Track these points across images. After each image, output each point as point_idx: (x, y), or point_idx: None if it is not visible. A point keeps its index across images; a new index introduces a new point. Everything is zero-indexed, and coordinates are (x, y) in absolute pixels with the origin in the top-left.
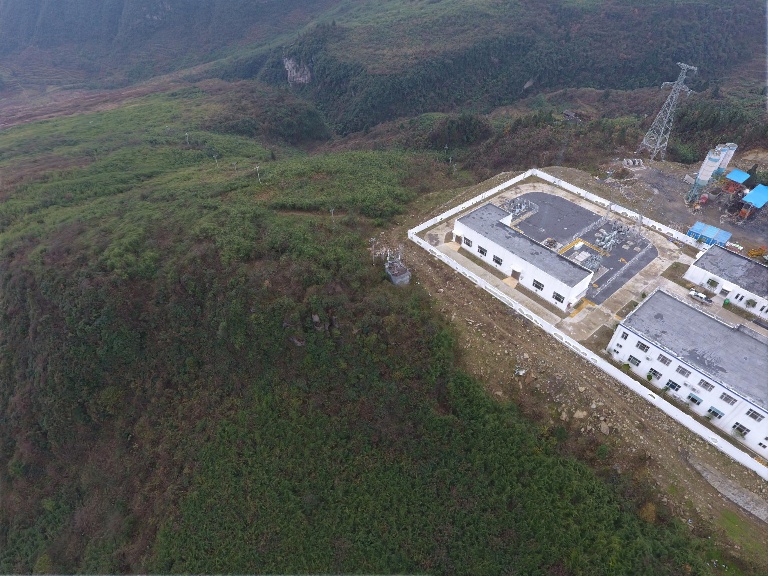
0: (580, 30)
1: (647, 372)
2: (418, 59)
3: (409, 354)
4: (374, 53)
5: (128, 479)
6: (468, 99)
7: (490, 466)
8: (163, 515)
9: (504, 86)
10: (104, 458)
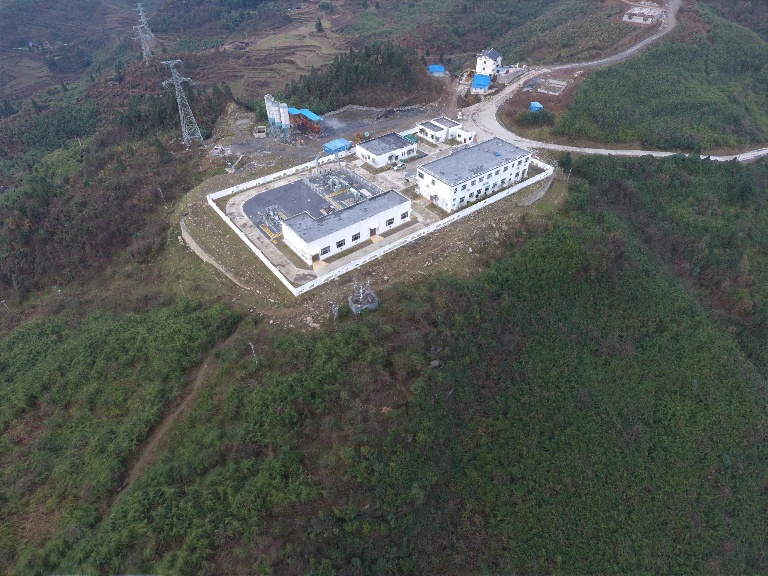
0: None
1: None
2: None
3: None
4: None
5: None
6: None
7: None
8: None
9: None
10: None
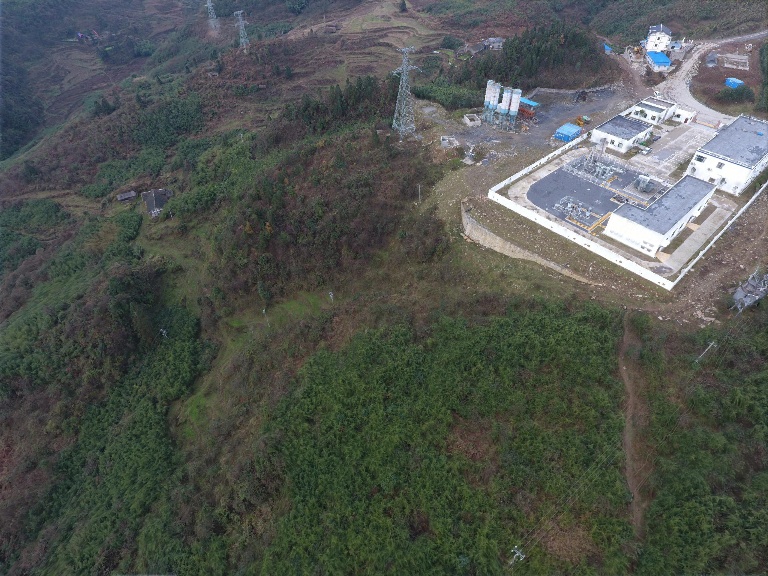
0: None
1: None
2: None
3: None
4: None
5: None
6: None
7: None
8: None
9: None
10: None
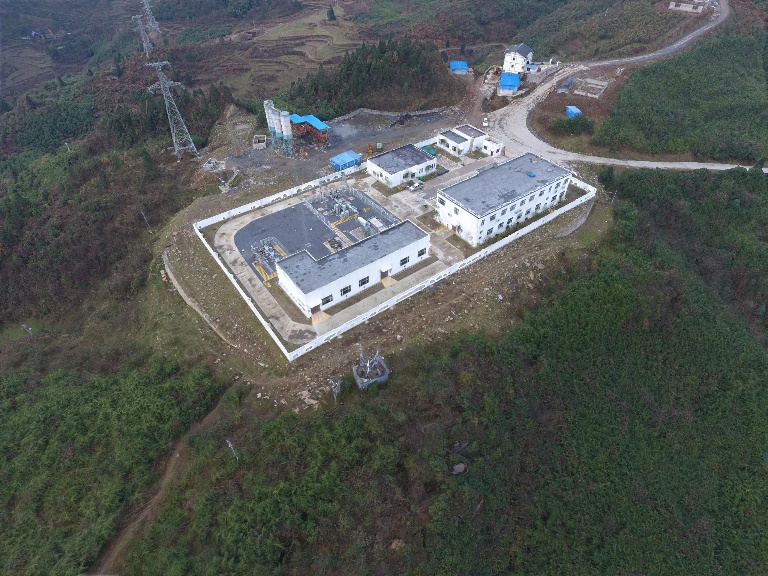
0: None
1: (497, 229)
2: None
3: None
4: None
5: None
6: None
7: None
8: None
9: None
10: None
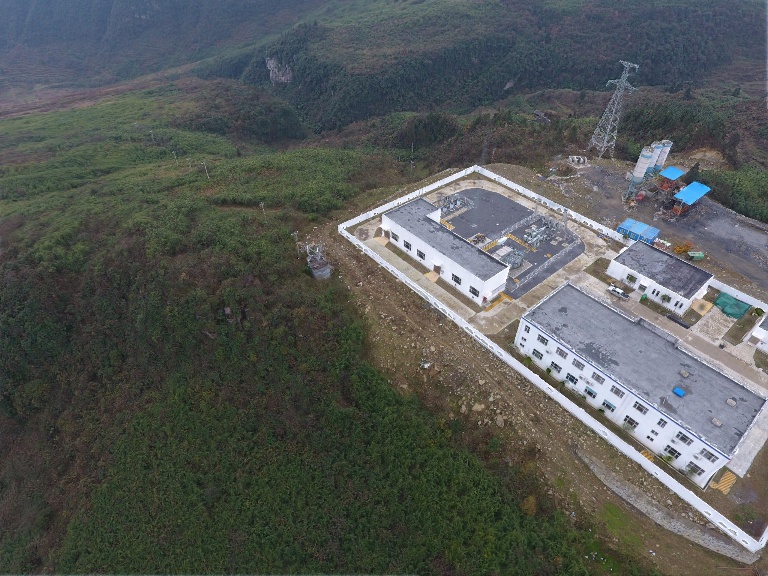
0: (560, 31)
1: (549, 366)
2: (397, 59)
3: (316, 347)
4: (354, 53)
5: (46, 472)
6: (448, 99)
7: (387, 459)
8: (76, 508)
9: (484, 87)
10: (24, 451)
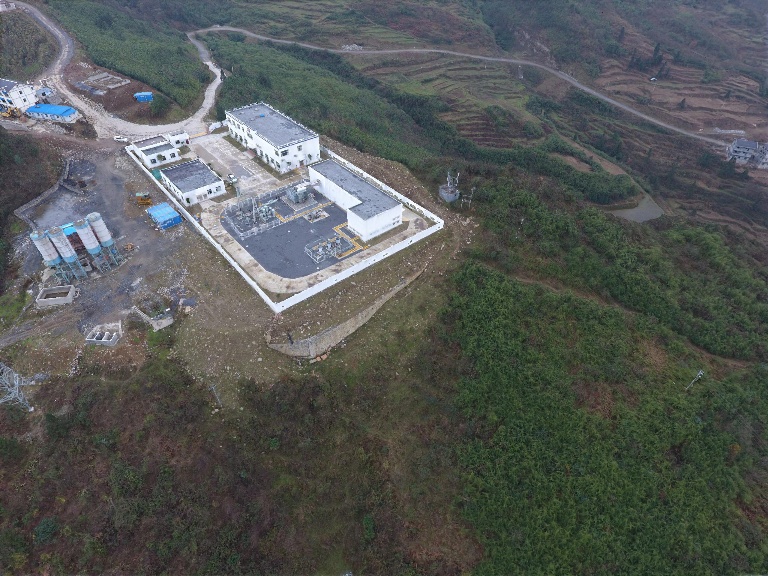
0: None
1: None
2: None
3: None
4: None
5: None
6: None
7: None
8: None
9: None
10: None
